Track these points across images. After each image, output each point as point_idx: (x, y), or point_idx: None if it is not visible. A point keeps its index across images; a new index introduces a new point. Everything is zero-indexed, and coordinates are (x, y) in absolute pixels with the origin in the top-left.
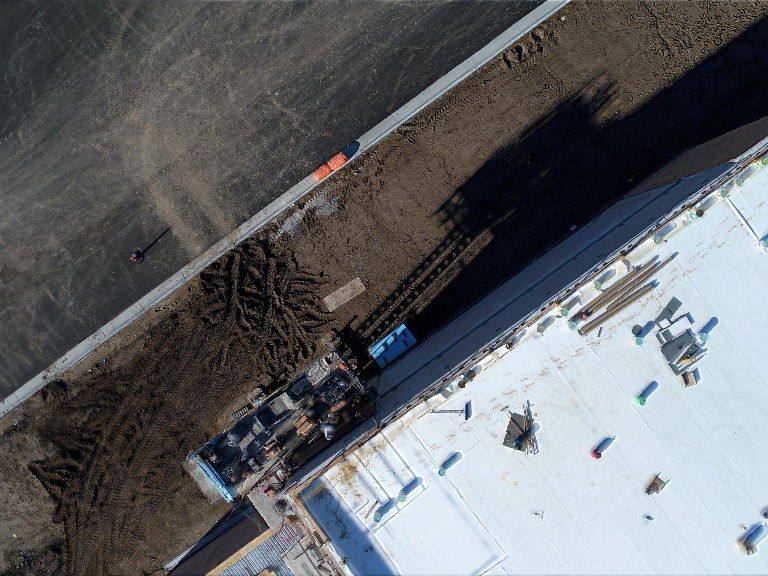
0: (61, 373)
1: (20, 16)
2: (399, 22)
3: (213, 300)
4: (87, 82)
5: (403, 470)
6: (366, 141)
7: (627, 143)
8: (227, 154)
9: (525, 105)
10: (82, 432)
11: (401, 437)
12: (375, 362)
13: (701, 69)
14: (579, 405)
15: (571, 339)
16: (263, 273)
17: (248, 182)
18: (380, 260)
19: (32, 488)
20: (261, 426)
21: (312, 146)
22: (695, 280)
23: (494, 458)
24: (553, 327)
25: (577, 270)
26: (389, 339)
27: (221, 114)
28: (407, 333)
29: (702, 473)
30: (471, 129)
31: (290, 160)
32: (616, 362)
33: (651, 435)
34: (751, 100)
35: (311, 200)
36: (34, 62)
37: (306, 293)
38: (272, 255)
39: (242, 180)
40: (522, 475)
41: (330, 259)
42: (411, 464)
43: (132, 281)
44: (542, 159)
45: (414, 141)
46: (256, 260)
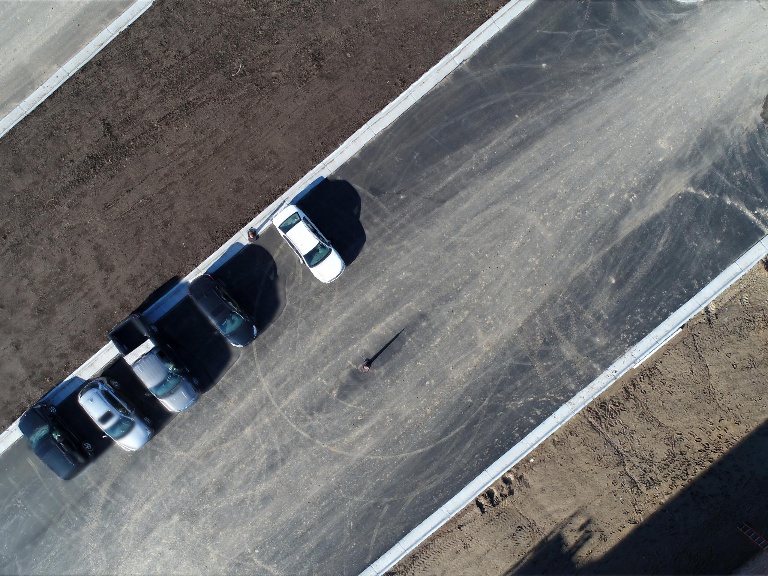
0: None
1: (0, 496)
2: (371, 475)
3: None
4: (71, 554)
5: None
6: None
7: None
8: None
9: (500, 549)
10: None
11: None
12: None
13: (670, 504)
14: None
15: None
16: None
17: None
18: None
19: None
20: None
21: None
22: None
23: None
24: None
25: None
26: None
27: (204, 574)
28: None
29: None
30: (449, 575)
31: None
32: None
33: None
34: (721, 531)
35: None
36: (17, 538)
37: None
38: None
39: None
40: None
41: None
42: None
43: None
44: None
45: None
46: None
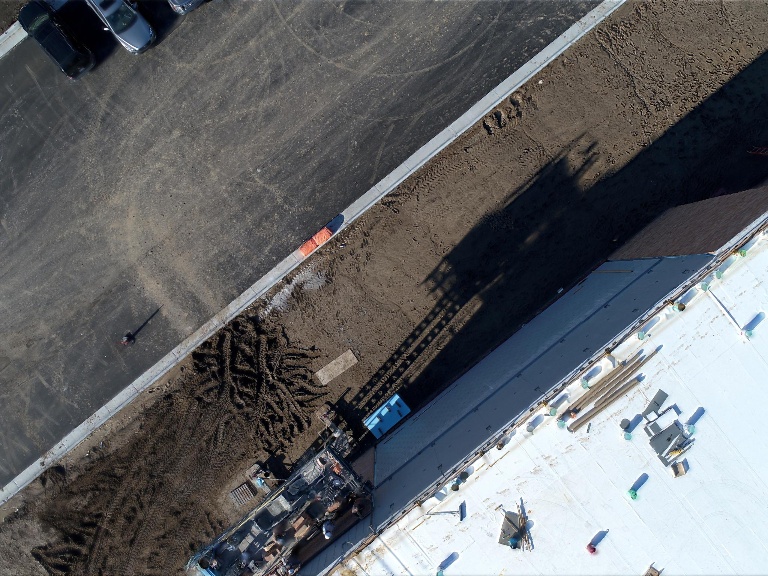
0: (59, 459)
1: None
2: (377, 93)
3: (206, 379)
4: (68, 168)
5: (401, 572)
6: (350, 214)
7: (610, 203)
8: (212, 233)
9: (507, 170)
10: (83, 516)
11: (398, 540)
12: (370, 433)
13: (679, 126)
14: (572, 500)
15: (561, 436)
16: (255, 350)
17: (235, 260)
18: (370, 331)
19: (36, 574)
20: (259, 529)
21: (297, 221)
22: (680, 372)
23: (490, 556)
24: (542, 426)
25: (564, 364)
26: (383, 410)
27: (204, 193)
28: (401, 403)
29: (695, 560)
30: (454, 197)
31: (276, 236)
32: (606, 456)
33: (644, 526)
34: (730, 155)
35: (299, 275)
36: (14, 151)
37: (298, 368)
38: (263, 331)
39: (229, 258)
40: (519, 571)
41: (321, 333)
42: (409, 566)
43: (124, 364)
44: (526, 223)
45: (398, 211)
46: (247, 337)
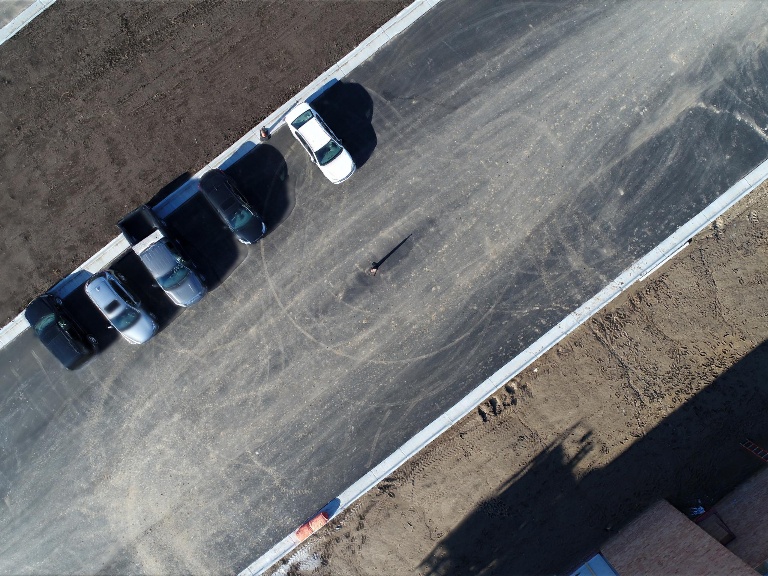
0: None
1: (3, 389)
2: (374, 380)
3: None
4: (71, 449)
5: None
6: (347, 498)
7: (603, 492)
8: (211, 513)
9: (501, 458)
10: None
11: None
12: None
13: (673, 417)
14: None
15: None
16: None
17: (232, 540)
18: None
19: None
20: None
21: (294, 503)
22: None
23: None
24: None
25: None
26: None
27: (203, 474)
28: None
29: None
30: (449, 483)
31: (273, 518)
32: None
33: None
34: (723, 447)
35: (295, 555)
36: (18, 432)
37: None
38: None
39: (226, 538)
40: None
41: None
42: None
43: None
44: (520, 511)
45: (394, 495)
46: None
